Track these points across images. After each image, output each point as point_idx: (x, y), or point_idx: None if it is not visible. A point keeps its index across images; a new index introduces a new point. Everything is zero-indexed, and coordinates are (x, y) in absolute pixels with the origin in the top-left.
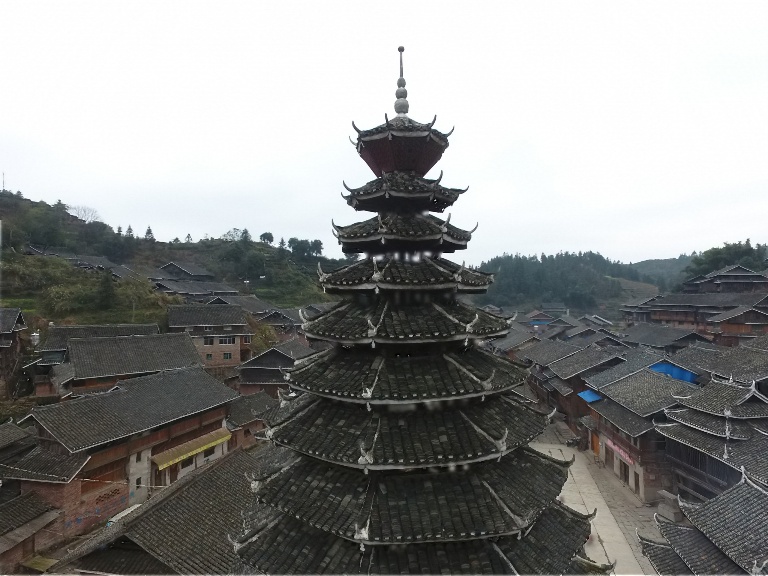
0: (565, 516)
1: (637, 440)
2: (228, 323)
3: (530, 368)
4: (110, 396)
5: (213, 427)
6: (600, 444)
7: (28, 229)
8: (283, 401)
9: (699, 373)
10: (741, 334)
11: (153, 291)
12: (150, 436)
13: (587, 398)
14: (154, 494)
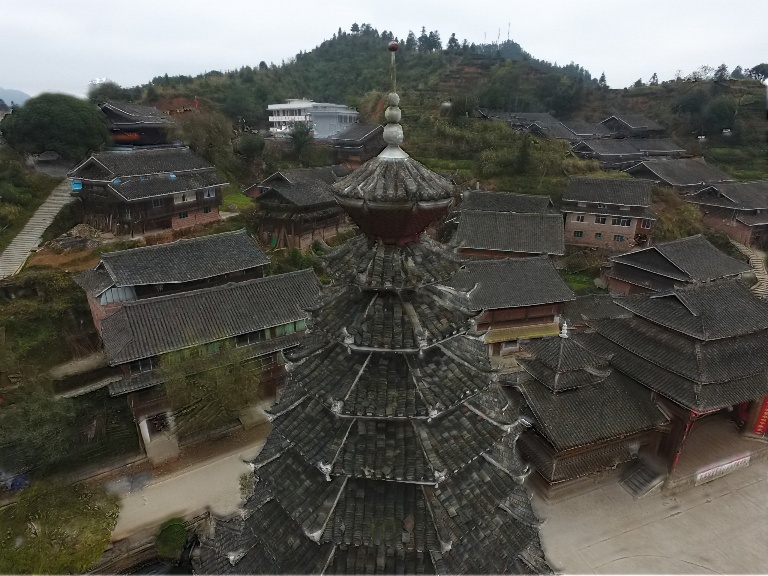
0: None
1: None
2: (625, 203)
3: (446, 544)
4: None
5: (543, 320)
6: None
7: (479, 94)
8: None
9: None
10: None
11: (566, 156)
12: None
13: None
14: None
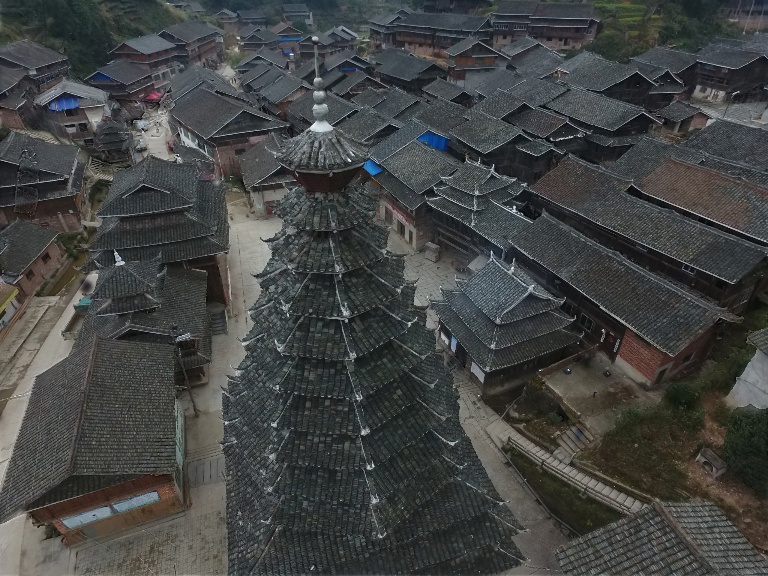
0: None
1: None
2: None
3: None
4: None
5: None
6: (381, 207)
7: None
8: (237, 371)
9: (450, 138)
10: (468, 67)
11: None
12: None
13: (370, 170)
14: None
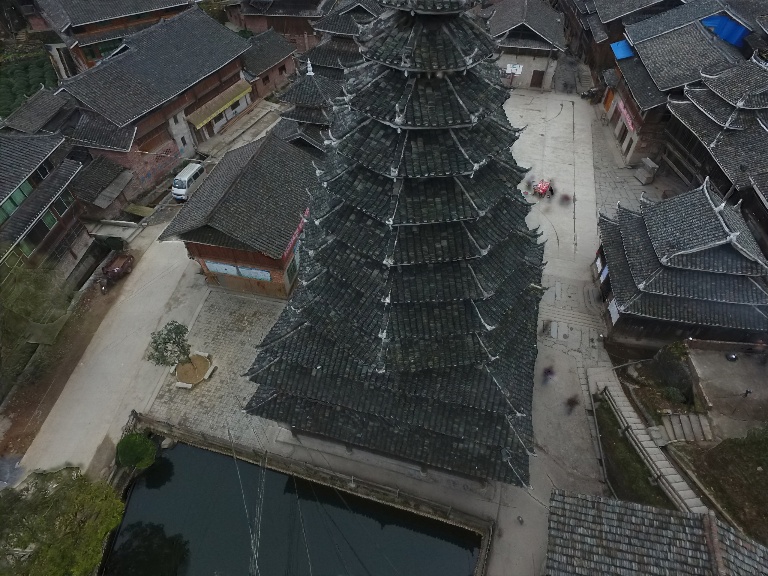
0: (525, 264)
1: (646, 111)
2: None
3: None
4: (124, 59)
5: (232, 80)
6: (612, 103)
7: None
8: (318, 170)
9: (754, 29)
10: None
11: None
12: (179, 100)
13: (618, 53)
14: (199, 148)
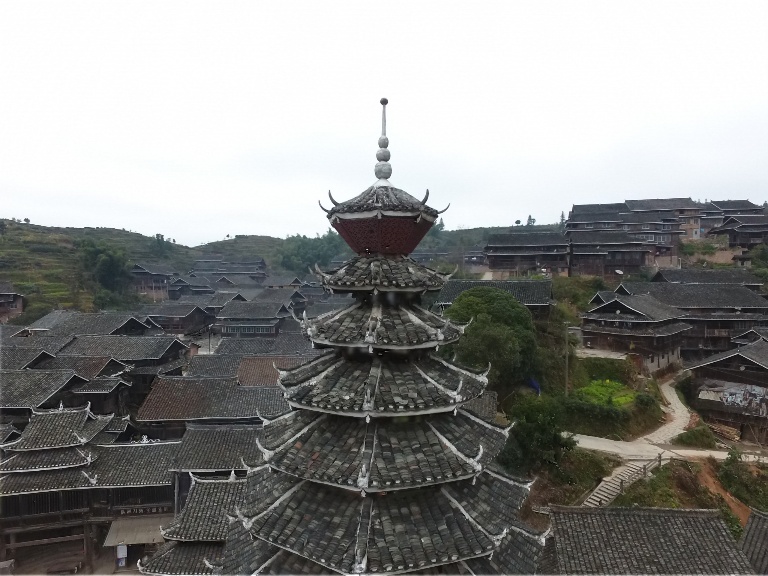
0: None
1: None
2: None
3: None
4: None
5: None
6: None
7: None
8: None
9: None
10: None
11: None
12: None
13: None
14: None
